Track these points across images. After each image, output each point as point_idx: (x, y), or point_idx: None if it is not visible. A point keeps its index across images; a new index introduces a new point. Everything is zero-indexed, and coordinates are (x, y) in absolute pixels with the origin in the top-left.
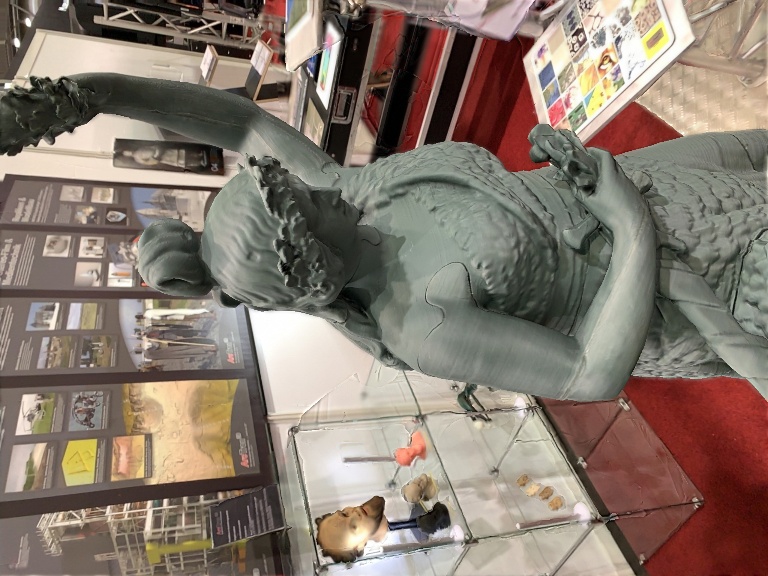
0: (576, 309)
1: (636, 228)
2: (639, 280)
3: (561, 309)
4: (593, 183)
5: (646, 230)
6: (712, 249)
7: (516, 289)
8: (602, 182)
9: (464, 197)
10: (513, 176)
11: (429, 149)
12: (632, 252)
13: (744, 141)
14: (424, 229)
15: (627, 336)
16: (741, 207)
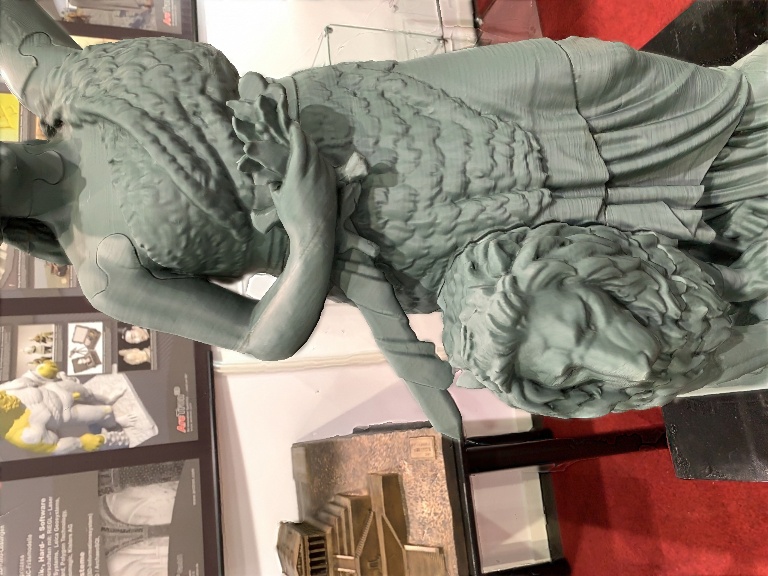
0: (280, 266)
1: (303, 247)
2: (299, 293)
3: (264, 265)
4: (277, 180)
5: (313, 251)
6: (422, 246)
7: (193, 263)
8: (284, 184)
9: (142, 158)
10: (220, 125)
11: (129, 64)
12: (296, 268)
13: (578, 70)
14: (101, 182)
15: (283, 333)
16: (493, 189)
